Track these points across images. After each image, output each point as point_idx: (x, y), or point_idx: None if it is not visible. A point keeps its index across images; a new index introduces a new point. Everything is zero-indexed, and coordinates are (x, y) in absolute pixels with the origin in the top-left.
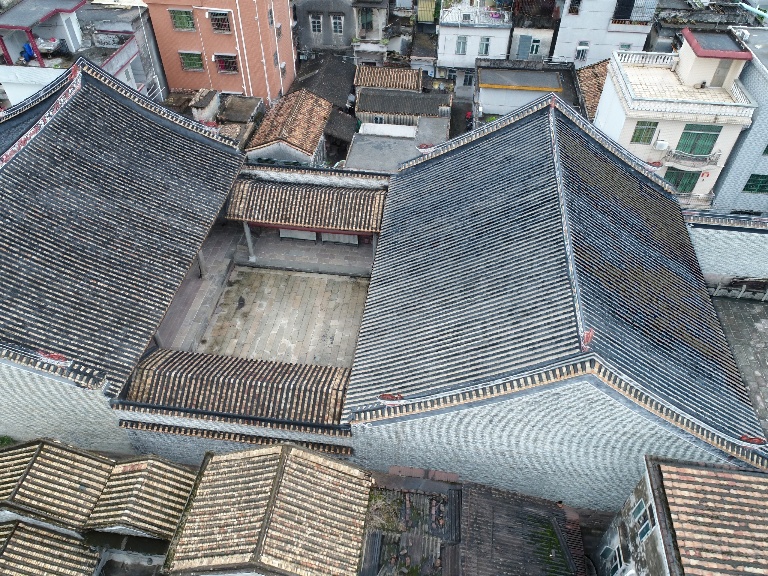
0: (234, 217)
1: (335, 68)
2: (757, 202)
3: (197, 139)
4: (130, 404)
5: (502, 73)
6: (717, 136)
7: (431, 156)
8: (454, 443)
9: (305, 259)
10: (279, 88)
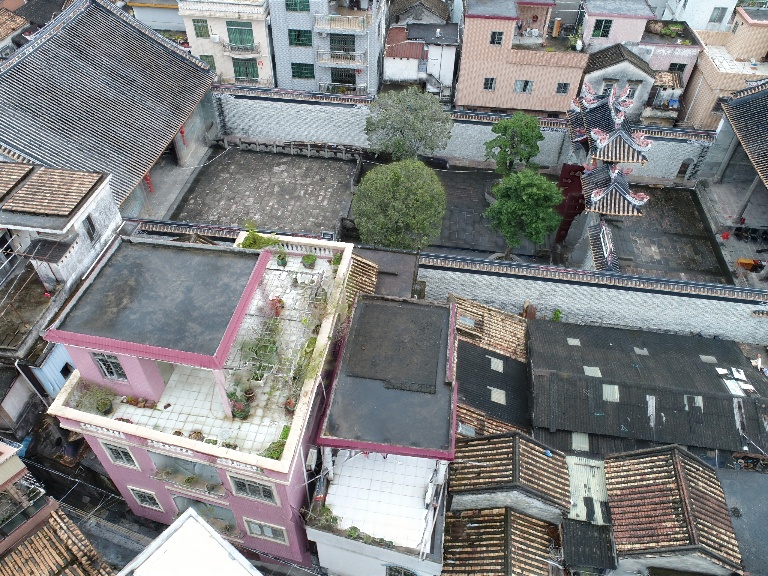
0: None
1: None
2: (308, 87)
3: None
4: None
5: None
6: (252, 31)
7: None
8: None
9: None
10: None
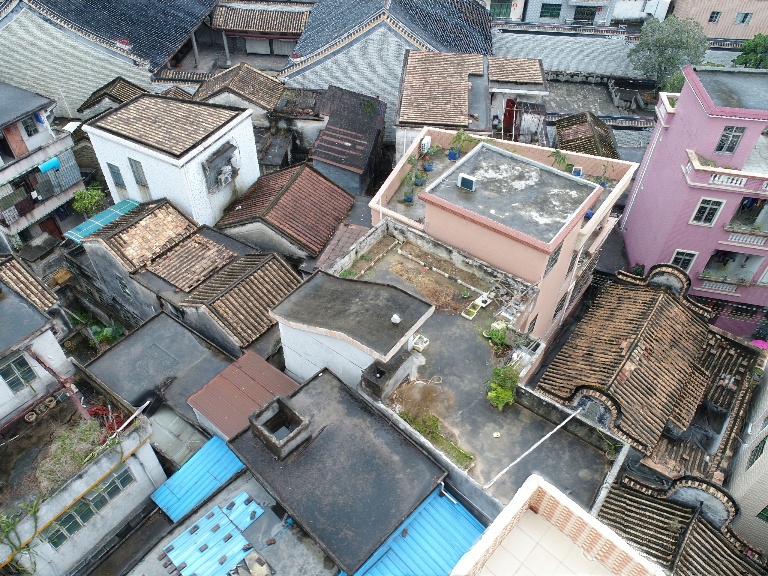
0: (216, 26)
1: None
2: None
3: None
4: (162, 79)
5: None
6: None
7: None
8: None
9: (263, 64)
10: None
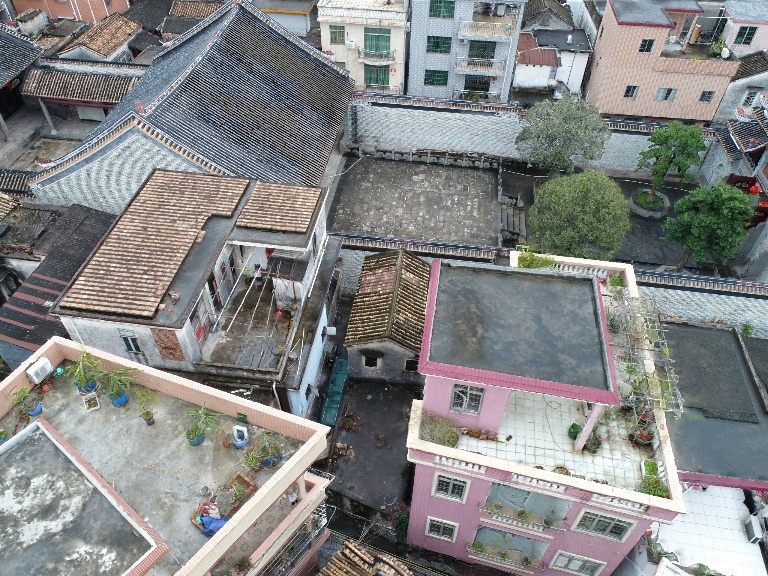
0: (27, 93)
1: (157, 3)
2: (438, 94)
3: (3, 36)
4: None
5: (270, 2)
6: (390, 37)
7: (171, 48)
8: (98, 200)
9: None
10: (104, 15)
